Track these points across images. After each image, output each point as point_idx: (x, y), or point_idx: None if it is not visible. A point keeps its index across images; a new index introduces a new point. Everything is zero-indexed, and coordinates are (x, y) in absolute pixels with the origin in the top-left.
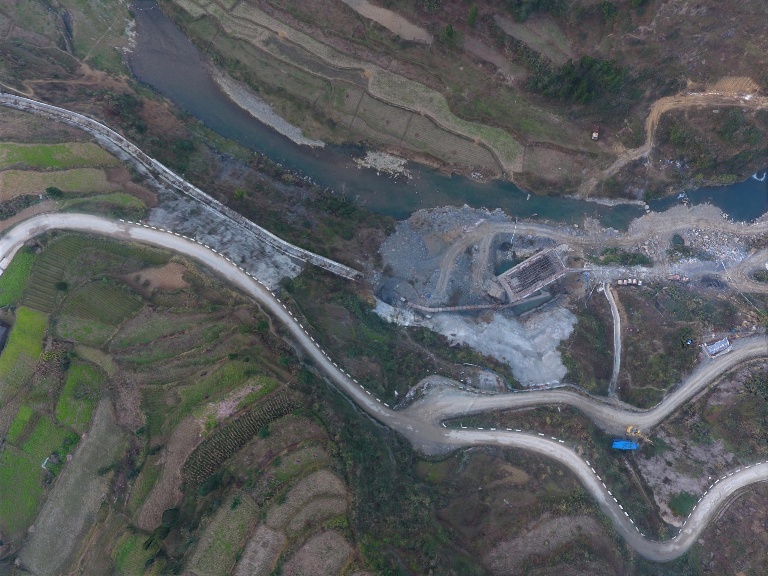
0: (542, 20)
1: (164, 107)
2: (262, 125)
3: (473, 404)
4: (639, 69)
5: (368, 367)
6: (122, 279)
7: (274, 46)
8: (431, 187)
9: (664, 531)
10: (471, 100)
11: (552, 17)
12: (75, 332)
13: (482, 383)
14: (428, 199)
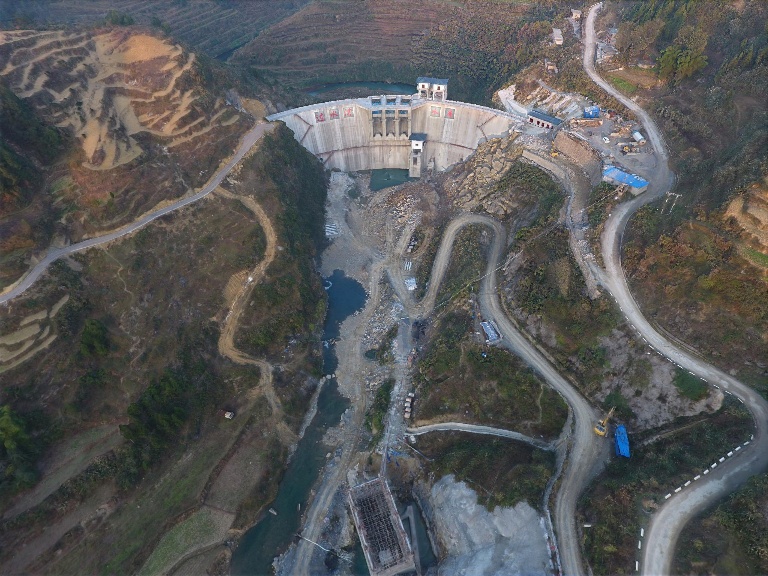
0: (56, 453)
1: None
2: None
3: None
4: (175, 359)
5: None
6: None
7: None
8: None
9: (737, 411)
10: None
11: (60, 440)
12: None
13: None
14: None
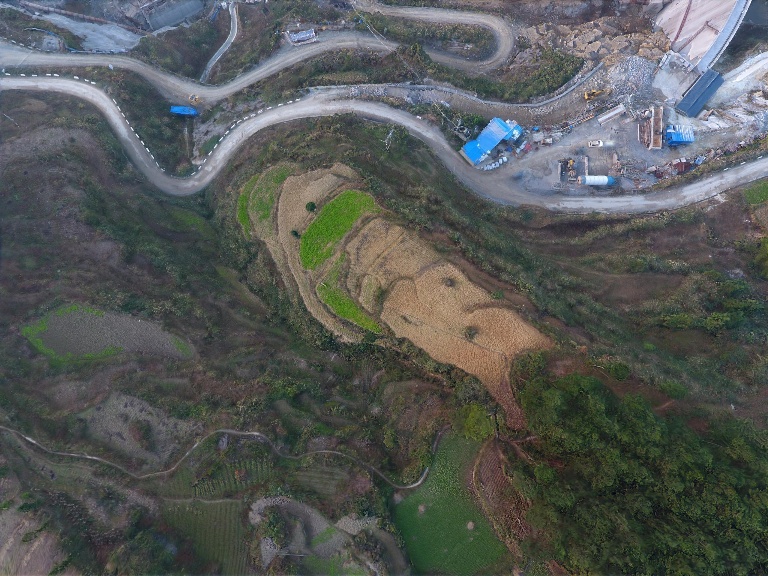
0: None
1: None
2: None
3: (26, 59)
4: None
5: None
6: None
7: None
8: None
9: (182, 166)
10: None
11: None
12: None
13: (44, 45)
14: None
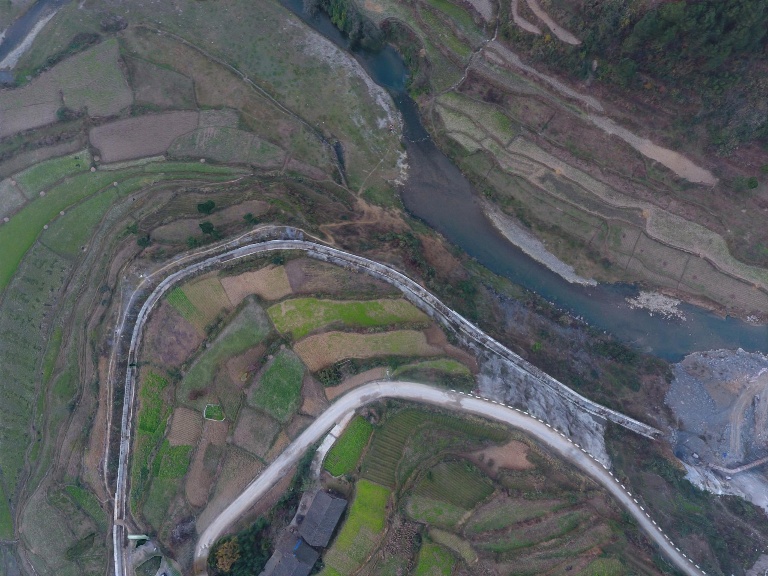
0: None
1: (439, 243)
2: (534, 262)
3: None
4: None
5: (699, 546)
6: (467, 458)
7: (550, 183)
8: (704, 329)
9: None
10: (753, 244)
11: None
12: (426, 513)
13: None
14: (701, 341)
